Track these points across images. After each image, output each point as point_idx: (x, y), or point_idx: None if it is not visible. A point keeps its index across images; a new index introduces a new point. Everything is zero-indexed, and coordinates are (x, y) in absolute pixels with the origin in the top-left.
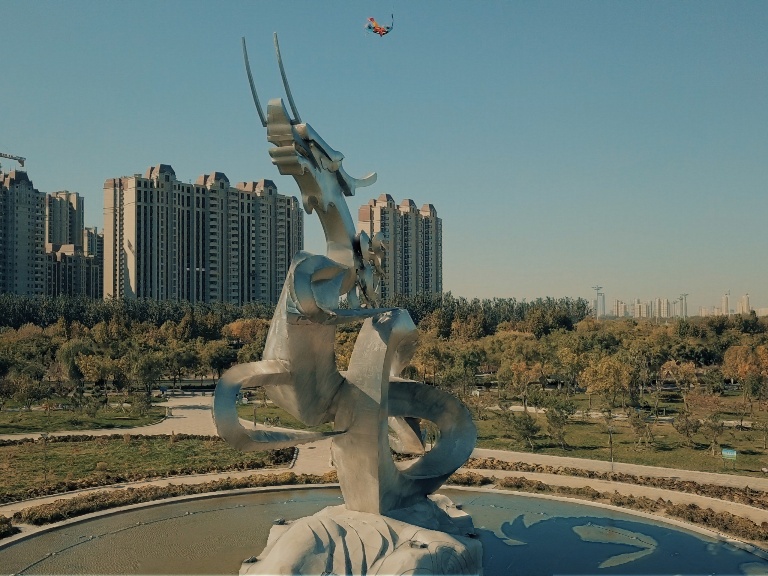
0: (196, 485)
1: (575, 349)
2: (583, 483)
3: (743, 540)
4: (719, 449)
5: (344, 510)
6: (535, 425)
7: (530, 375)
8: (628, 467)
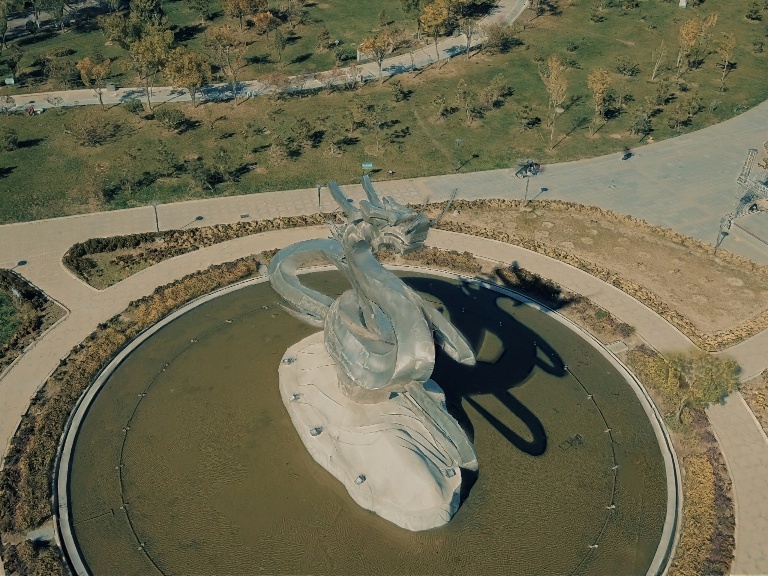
0: (62, 390)
1: (122, 27)
2: (312, 235)
3: (471, 275)
4: (336, 148)
5: (359, 405)
6: (206, 168)
7: (100, 72)
8: (306, 195)
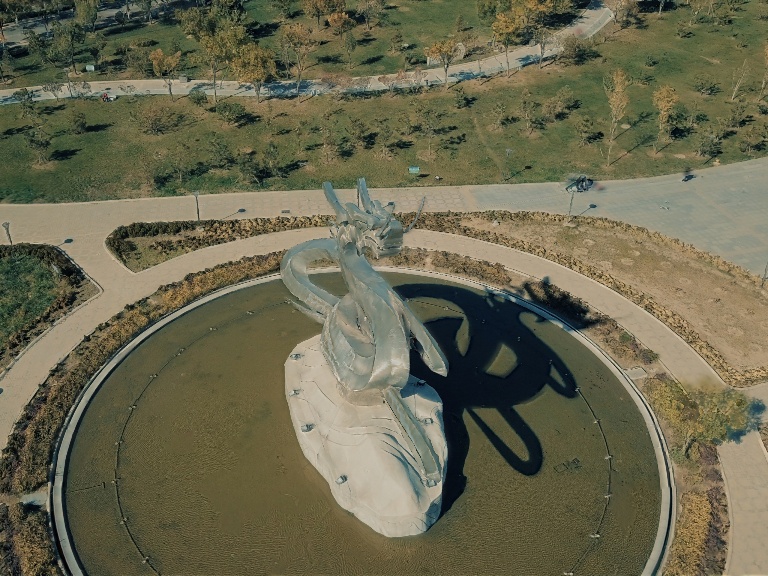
0: (80, 364)
1: (197, 21)
2: None
3: (499, 287)
4: (388, 150)
5: (353, 406)
6: (255, 162)
7: (171, 63)
8: (349, 195)
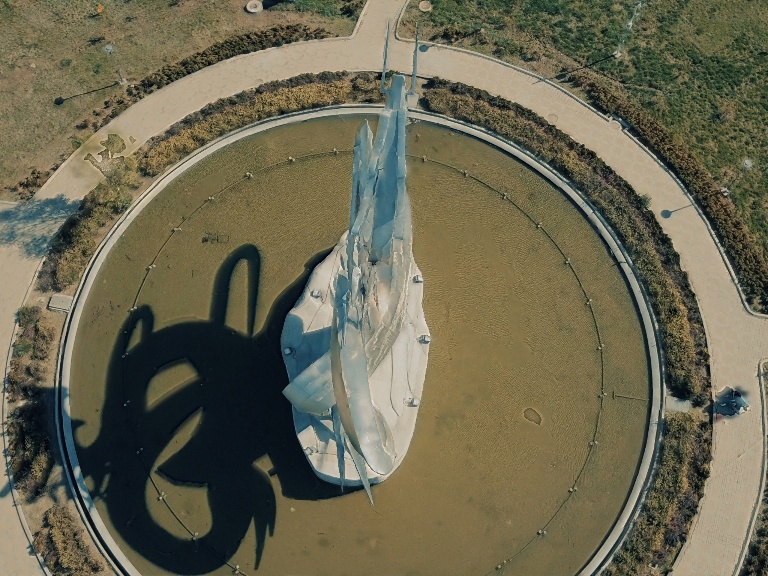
0: None
1: None
2: None
3: (73, 506)
4: None
5: None
6: None
7: None
8: None
